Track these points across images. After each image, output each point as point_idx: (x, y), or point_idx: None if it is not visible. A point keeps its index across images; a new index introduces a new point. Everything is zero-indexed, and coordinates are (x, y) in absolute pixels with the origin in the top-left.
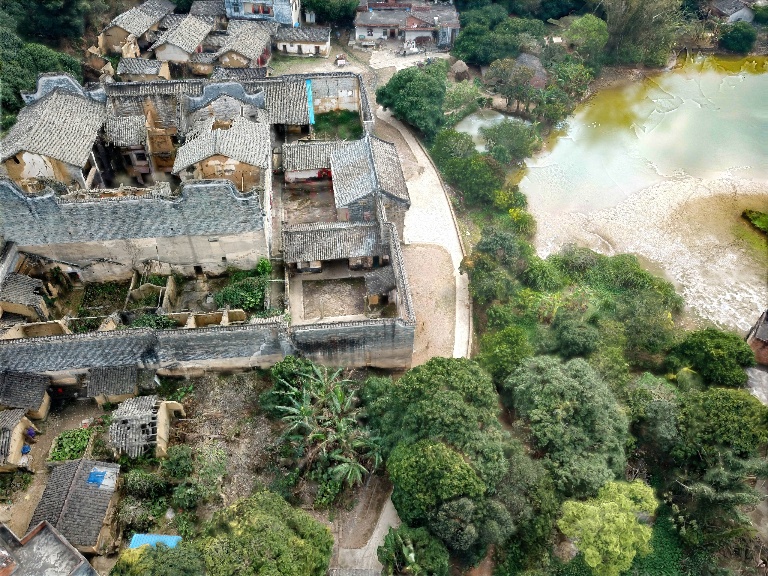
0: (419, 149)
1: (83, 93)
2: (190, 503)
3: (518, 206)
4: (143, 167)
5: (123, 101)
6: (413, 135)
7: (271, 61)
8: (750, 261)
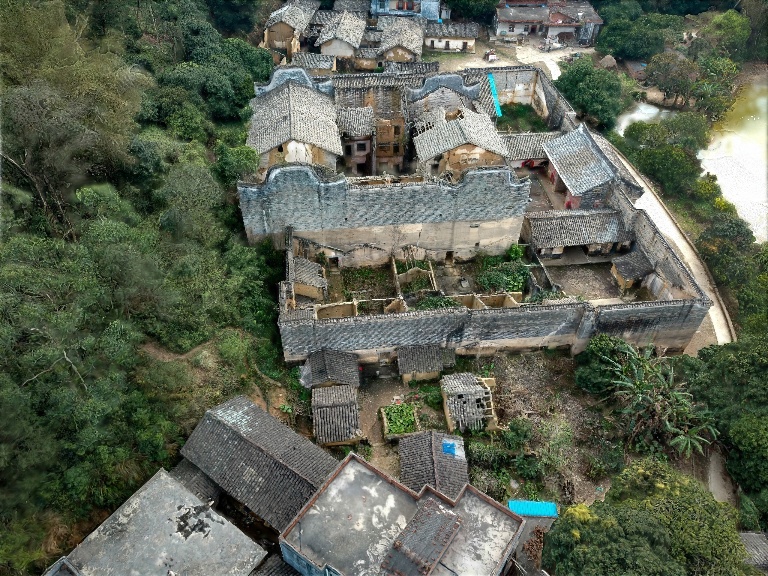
0: None
1: (312, 85)
2: (535, 473)
3: (716, 196)
4: (360, 157)
5: (347, 93)
6: (590, 127)
7: (421, 56)
8: None
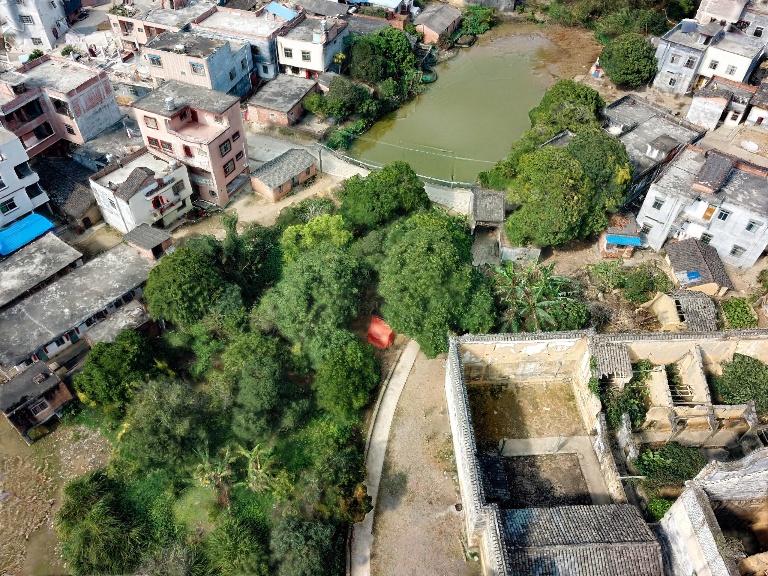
0: None
1: None
2: None
3: None
4: None
5: None
6: None
7: None
8: None
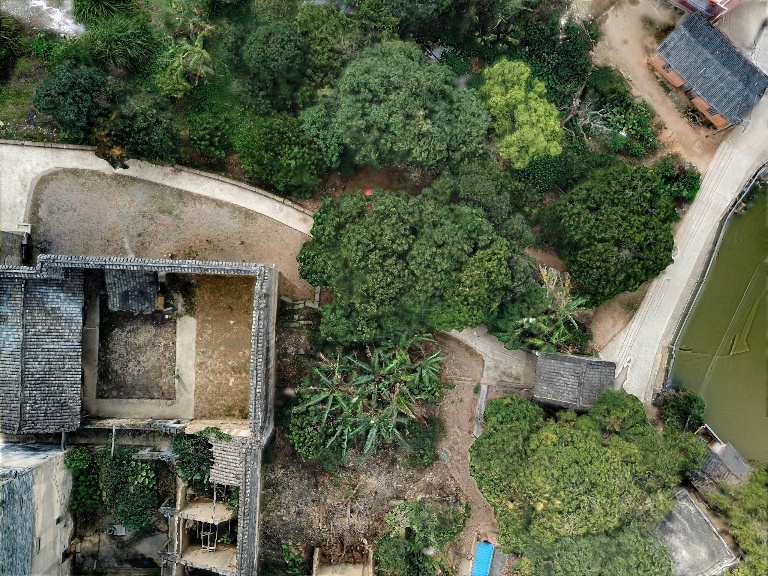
0: None
1: None
2: None
3: None
4: None
5: None
6: None
7: None
8: None
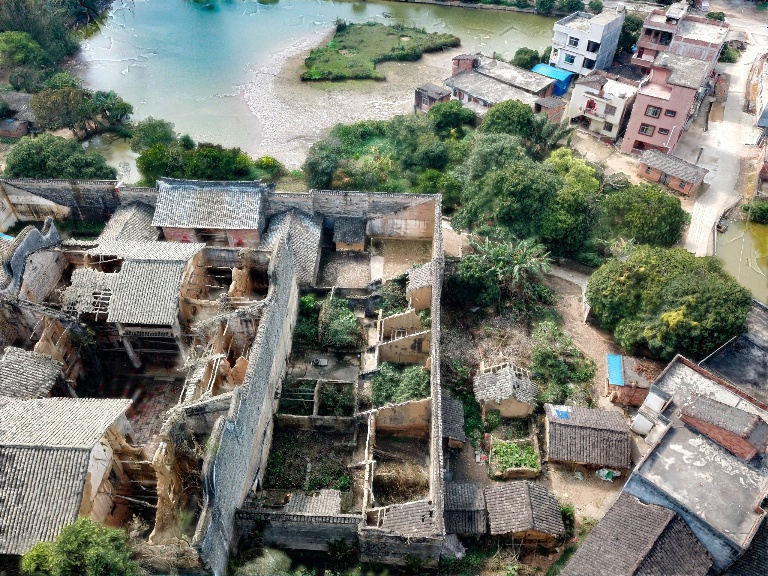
0: None
1: None
2: (567, 365)
3: None
4: None
5: None
6: None
7: None
8: (347, 93)
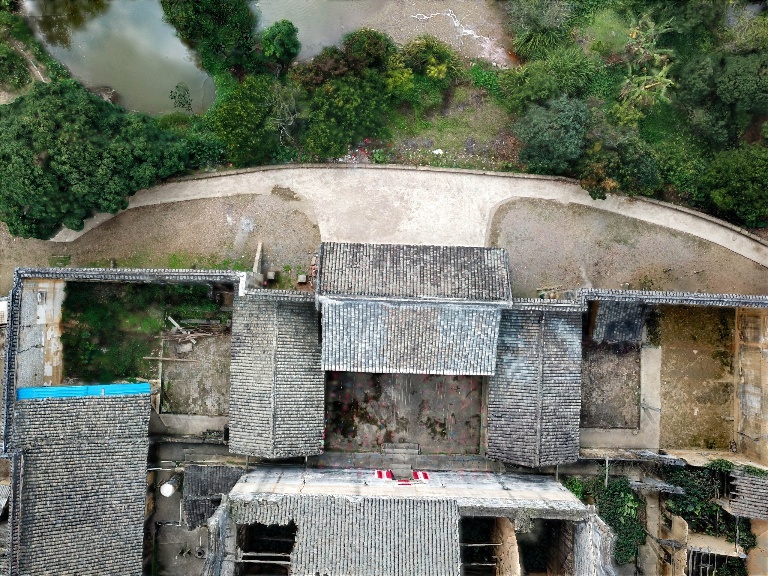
0: (212, 182)
1: None
2: None
3: None
4: None
5: None
6: (162, 184)
7: None
8: None
